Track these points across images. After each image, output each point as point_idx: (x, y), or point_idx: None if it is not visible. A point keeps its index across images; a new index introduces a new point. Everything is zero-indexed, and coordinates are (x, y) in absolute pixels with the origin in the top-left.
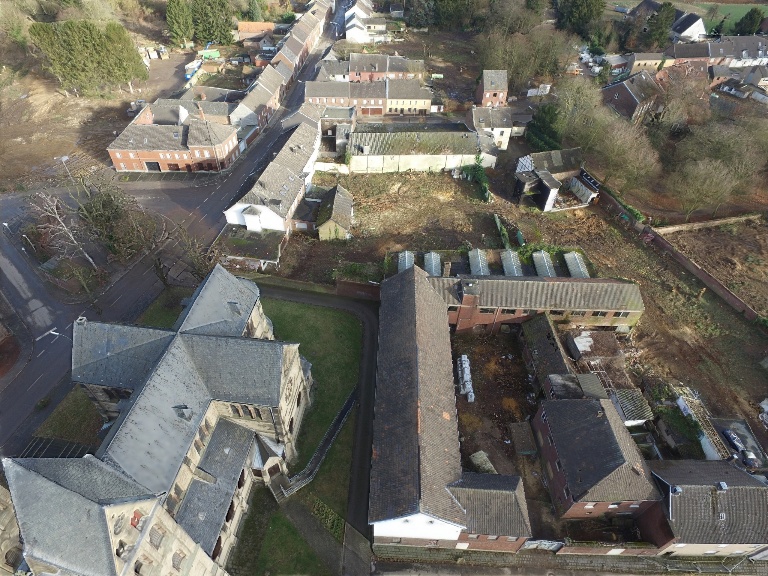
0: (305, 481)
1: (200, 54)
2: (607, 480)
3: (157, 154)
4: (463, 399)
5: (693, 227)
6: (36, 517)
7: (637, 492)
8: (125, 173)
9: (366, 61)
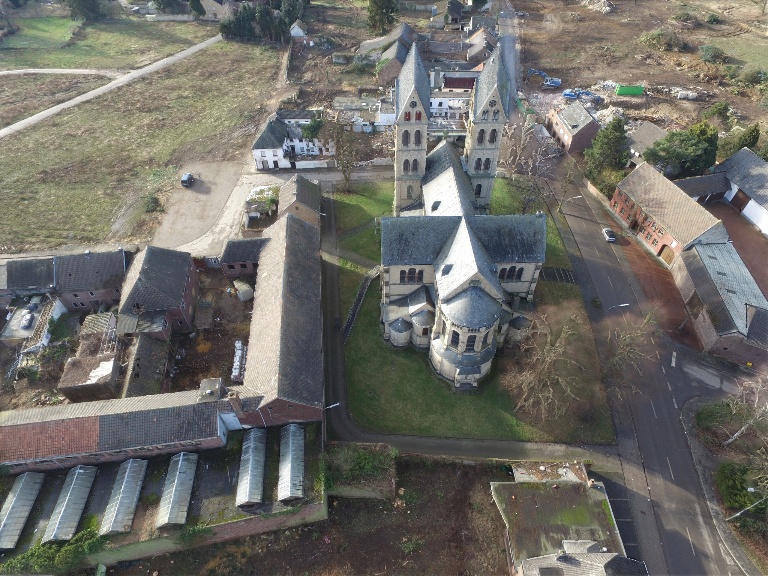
0: None
1: None
2: None
3: None
4: (246, 345)
5: None
6: None
7: None
8: None
9: None
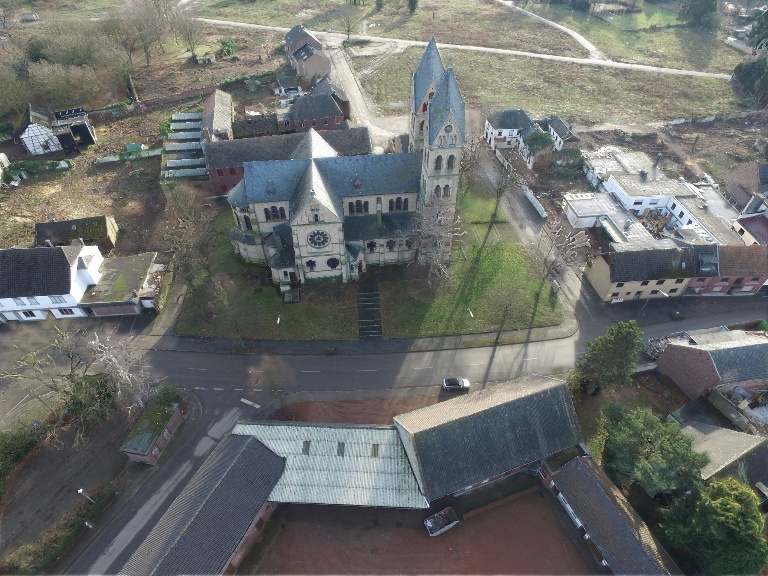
0: None
1: None
2: None
3: None
4: None
5: None
6: None
7: None
8: None
9: None
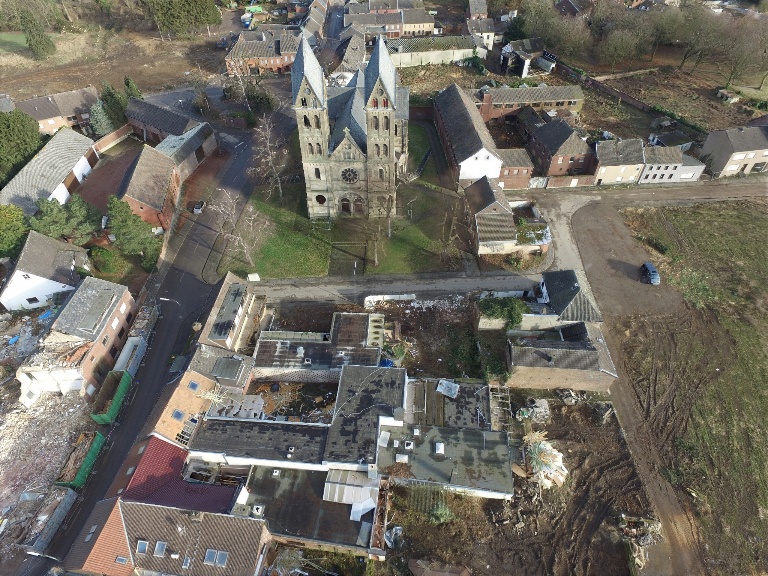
0: (417, 175)
1: (247, 9)
2: (567, 142)
3: (259, 61)
4: None
5: (616, 77)
6: None
7: (581, 149)
8: None
9: (381, 2)
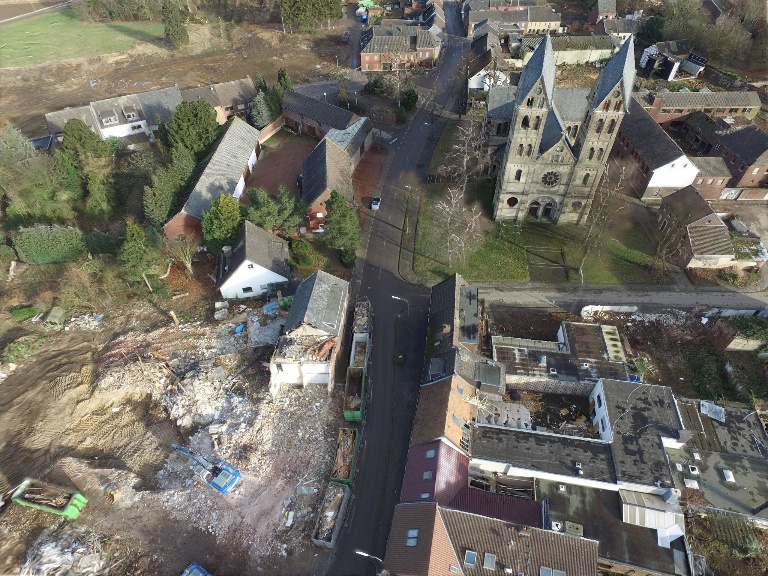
0: None
1: (360, 3)
2: (767, 152)
3: (393, 56)
4: None
5: None
6: (627, 63)
7: None
8: (368, 72)
9: None
